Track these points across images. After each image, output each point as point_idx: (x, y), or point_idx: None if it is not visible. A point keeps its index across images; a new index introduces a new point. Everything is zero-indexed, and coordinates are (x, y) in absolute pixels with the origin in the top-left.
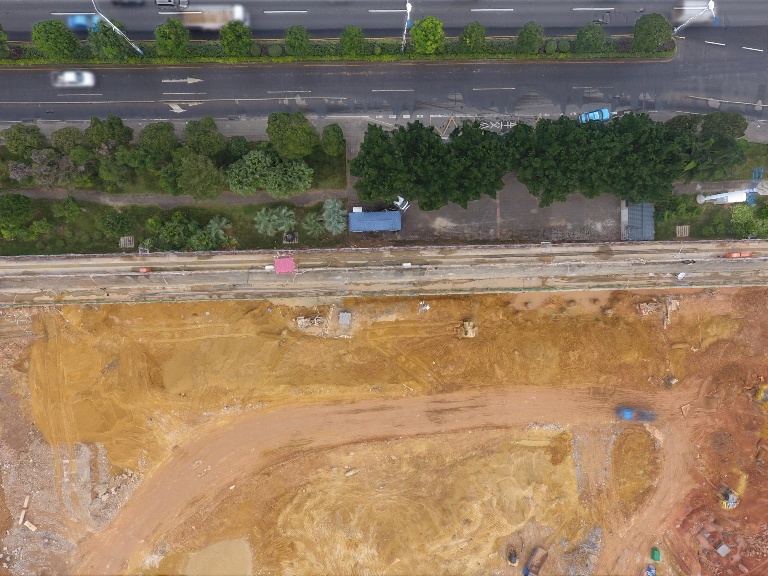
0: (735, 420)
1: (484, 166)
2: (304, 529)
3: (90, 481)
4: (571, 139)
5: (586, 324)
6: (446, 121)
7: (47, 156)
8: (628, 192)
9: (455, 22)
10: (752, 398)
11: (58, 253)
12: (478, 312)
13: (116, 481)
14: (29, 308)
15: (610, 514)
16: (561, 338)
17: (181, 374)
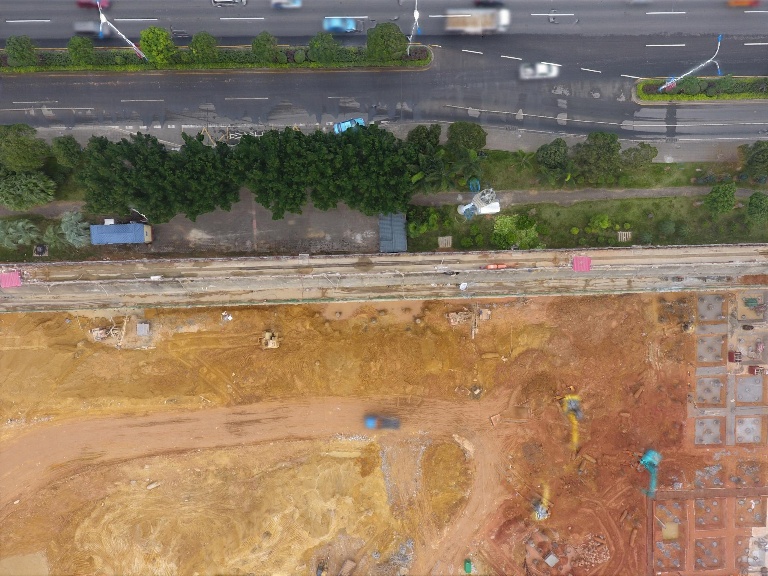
0: (546, 430)
1: (201, 179)
2: (101, 543)
3: None
4: (290, 151)
5: (395, 334)
6: (198, 131)
7: None
8: (359, 204)
9: None
10: (562, 408)
11: None
12: (283, 322)
13: None
14: None
15: (423, 525)
16: (365, 348)
17: None
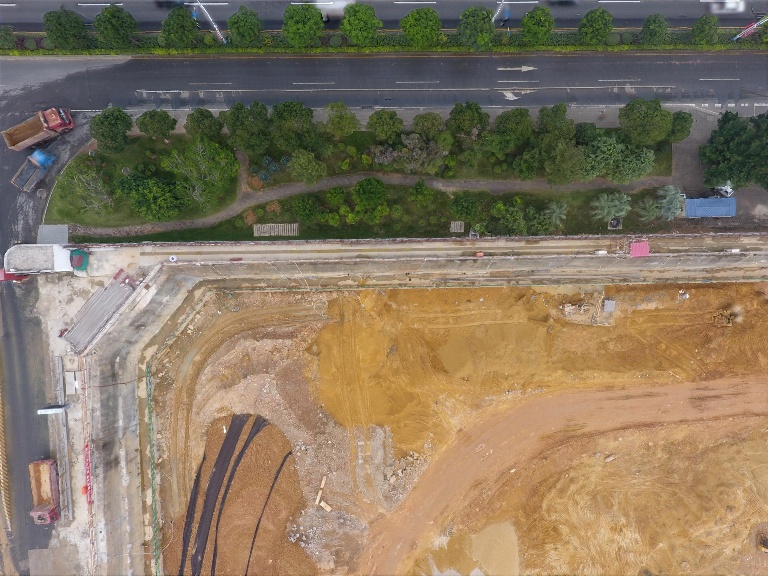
0: None
1: None
2: (569, 513)
3: (382, 463)
4: None
5: None
6: None
7: None
8: None
9: None
10: None
11: (392, 237)
12: (734, 301)
13: (401, 463)
14: (330, 292)
15: None
16: None
17: (464, 359)
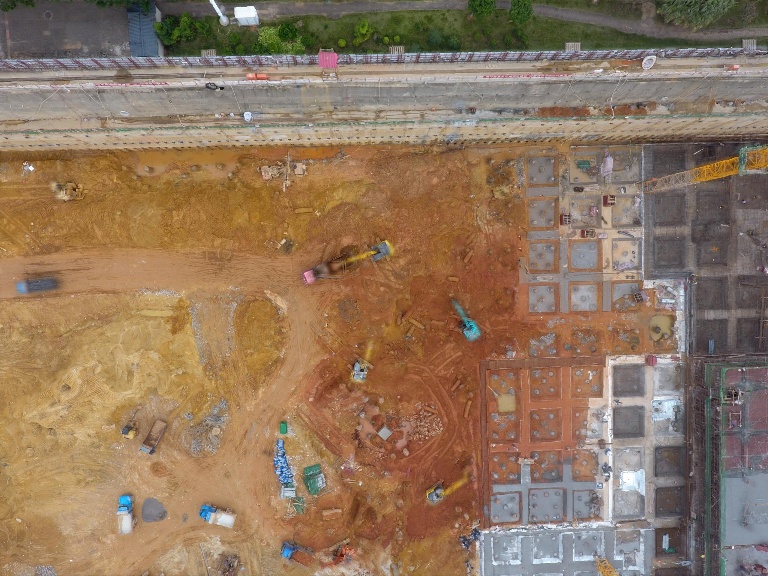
0: (362, 287)
1: None
2: None
3: None
4: None
5: (205, 188)
6: None
7: None
8: None
9: None
10: (378, 263)
11: None
12: (88, 174)
13: None
14: None
15: (238, 387)
16: (170, 199)
17: None
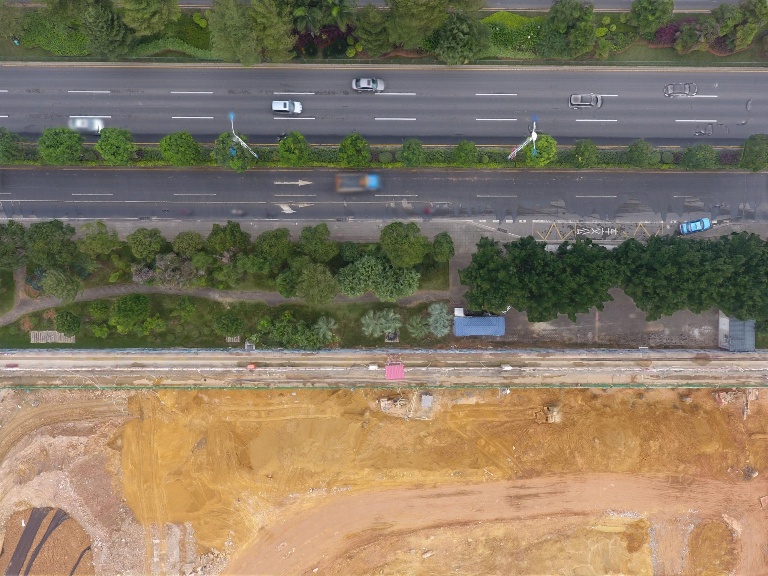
0: None
1: (598, 285)
2: None
3: (179, 561)
4: (684, 260)
5: (665, 411)
6: (548, 226)
7: (171, 262)
8: (736, 310)
9: (560, 131)
10: None
11: (167, 346)
12: (557, 397)
13: (202, 560)
14: (128, 390)
15: None
16: (641, 426)
17: (269, 456)
